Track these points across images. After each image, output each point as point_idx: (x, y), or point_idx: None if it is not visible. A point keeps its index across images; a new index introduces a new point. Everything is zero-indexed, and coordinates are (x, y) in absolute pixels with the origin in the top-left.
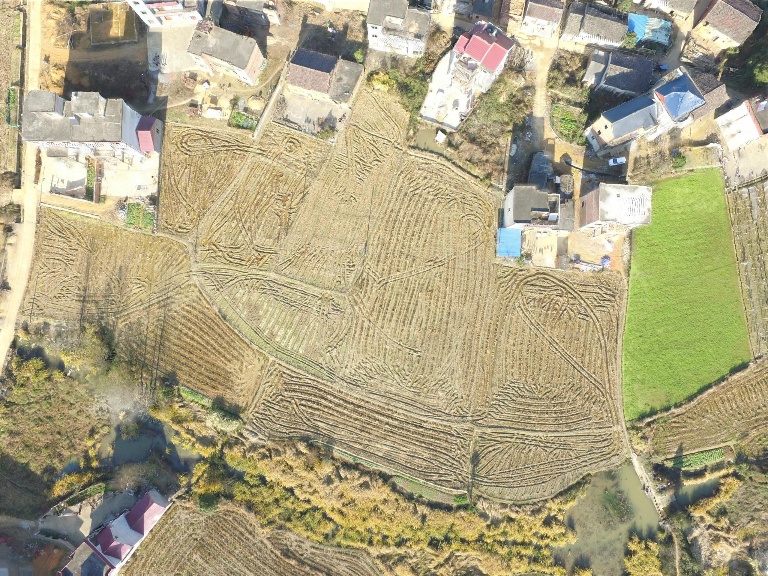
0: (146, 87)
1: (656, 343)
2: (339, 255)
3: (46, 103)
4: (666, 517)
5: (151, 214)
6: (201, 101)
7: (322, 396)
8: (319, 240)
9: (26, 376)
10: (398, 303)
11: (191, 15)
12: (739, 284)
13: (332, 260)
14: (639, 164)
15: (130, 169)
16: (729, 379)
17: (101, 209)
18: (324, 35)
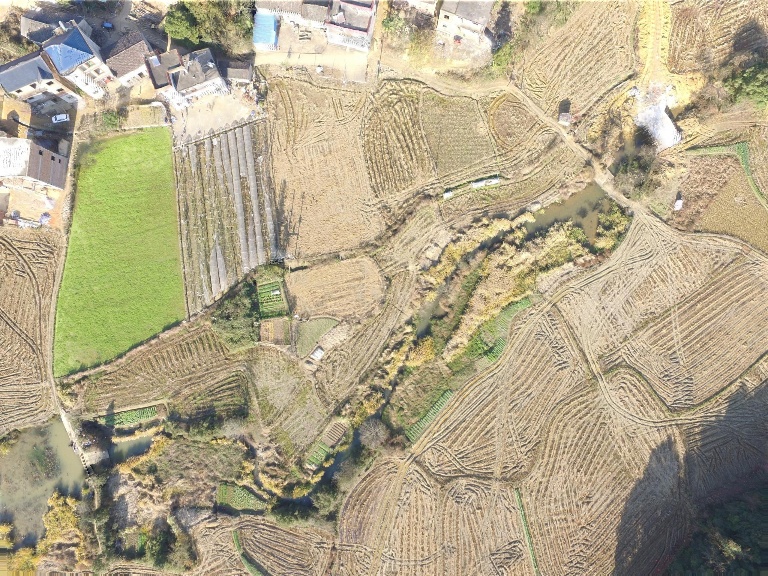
0: None
1: (91, 300)
2: None
3: None
4: (93, 474)
5: None
6: None
7: None
8: None
9: None
10: None
11: None
12: (179, 243)
13: None
14: (86, 122)
15: None
16: (159, 337)
17: None
18: None
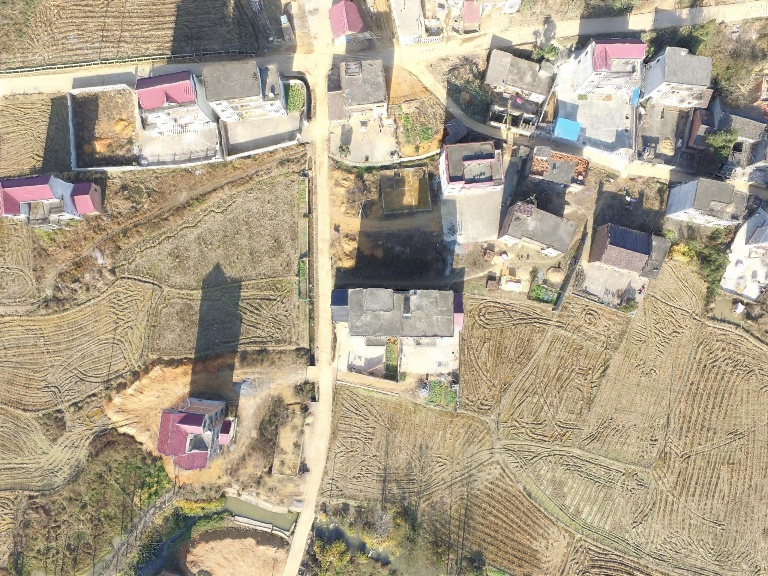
0: (442, 259)
1: None
2: (641, 429)
3: (384, 302)
4: None
5: (453, 391)
6: (499, 273)
7: (628, 572)
8: (622, 415)
9: (330, 560)
10: (701, 477)
11: (494, 187)
12: None
13: (635, 435)
14: None
15: (430, 345)
16: None
17: (401, 386)
18: (620, 203)
